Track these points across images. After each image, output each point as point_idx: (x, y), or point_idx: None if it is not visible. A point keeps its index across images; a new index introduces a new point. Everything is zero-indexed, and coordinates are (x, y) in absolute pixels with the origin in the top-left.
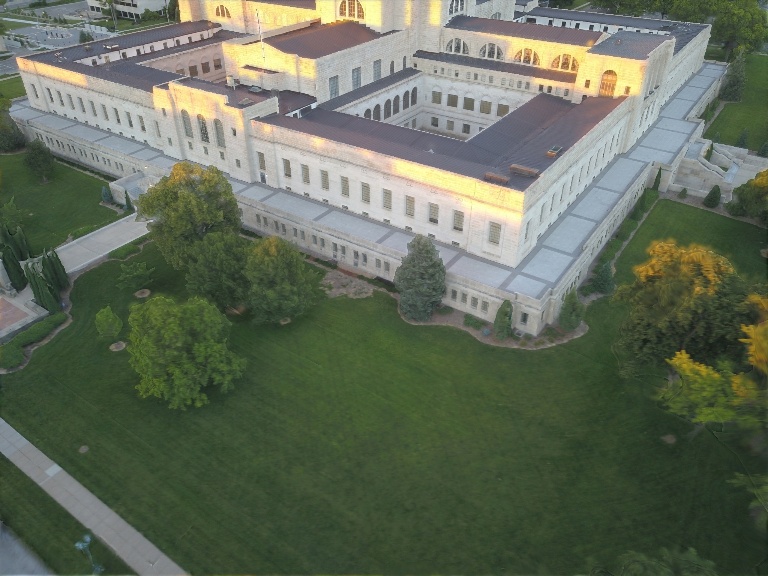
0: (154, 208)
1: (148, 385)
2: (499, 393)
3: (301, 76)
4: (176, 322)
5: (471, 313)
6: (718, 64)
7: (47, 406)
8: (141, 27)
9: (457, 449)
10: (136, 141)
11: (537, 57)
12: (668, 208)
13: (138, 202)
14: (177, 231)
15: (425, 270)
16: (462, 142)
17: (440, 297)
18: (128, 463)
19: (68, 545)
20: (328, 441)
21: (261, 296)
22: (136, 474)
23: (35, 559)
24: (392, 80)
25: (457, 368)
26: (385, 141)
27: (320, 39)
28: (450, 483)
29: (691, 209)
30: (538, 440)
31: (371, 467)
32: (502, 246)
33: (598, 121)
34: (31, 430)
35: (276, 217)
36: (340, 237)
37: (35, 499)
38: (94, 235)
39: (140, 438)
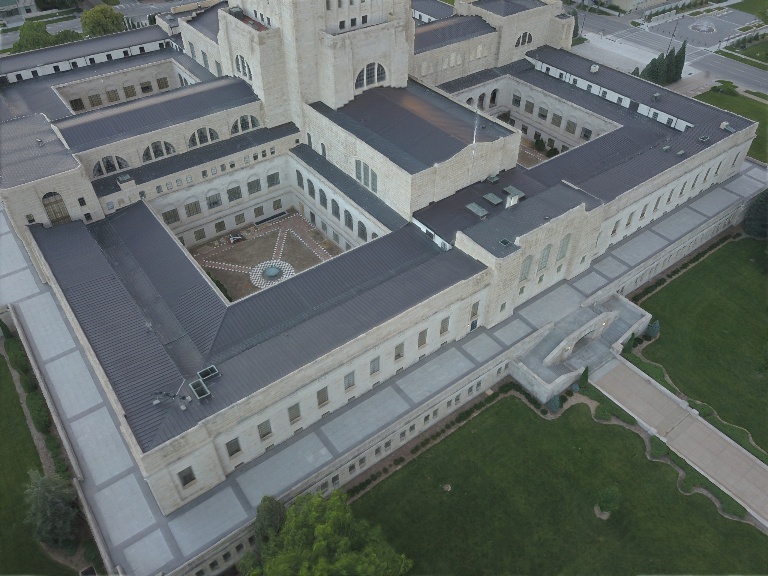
0: None
1: None
2: None
3: None
4: None
5: None
6: None
7: None
8: (761, 61)
9: None
10: None
11: None
12: None
13: None
14: None
15: None
16: None
17: None
18: None
19: (4, 51)
20: None
21: None
22: None
23: (7, 48)
24: None
25: None
26: (76, 56)
27: None
28: None
29: None
30: None
31: None
32: None
33: None
34: None
35: None
36: None
37: None
38: None
39: None
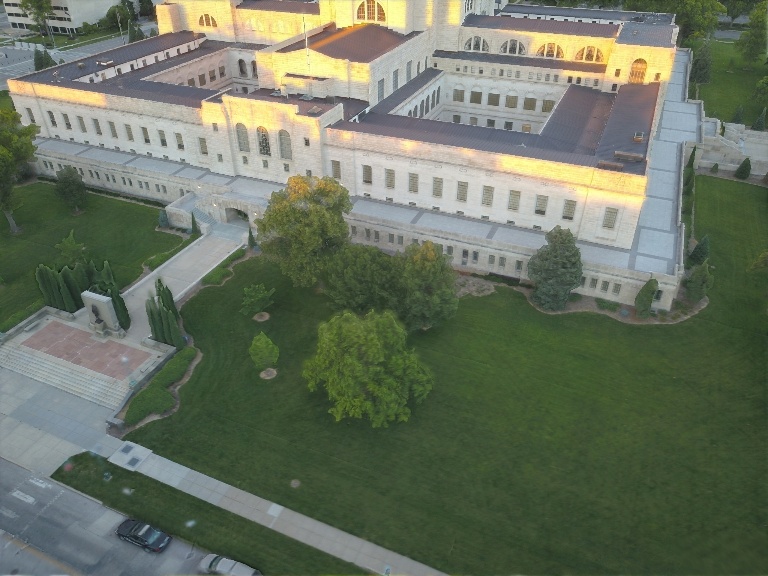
0: (283, 225)
1: (345, 407)
2: (668, 367)
3: (352, 81)
4: (375, 337)
5: (600, 297)
6: (679, 50)
7: (229, 446)
8: (80, 42)
9: (661, 424)
10: (170, 161)
11: (560, 50)
12: (708, 183)
13: (259, 221)
14: (309, 247)
15: (567, 259)
16: (536, 135)
17: (579, 284)
18: (352, 490)
19: None
20: (539, 436)
21: (421, 303)
22: (367, 499)
23: None
24: (421, 81)
25: (616, 350)
26: (471, 139)
27: (354, 43)
28: (674, 456)
29: (727, 182)
30: (727, 405)
31: (594, 454)
32: (618, 230)
33: (651, 106)
34: (225, 473)
35: (369, 225)
36: (448, 238)
37: (274, 543)
38: (171, 263)
39: (350, 463)
